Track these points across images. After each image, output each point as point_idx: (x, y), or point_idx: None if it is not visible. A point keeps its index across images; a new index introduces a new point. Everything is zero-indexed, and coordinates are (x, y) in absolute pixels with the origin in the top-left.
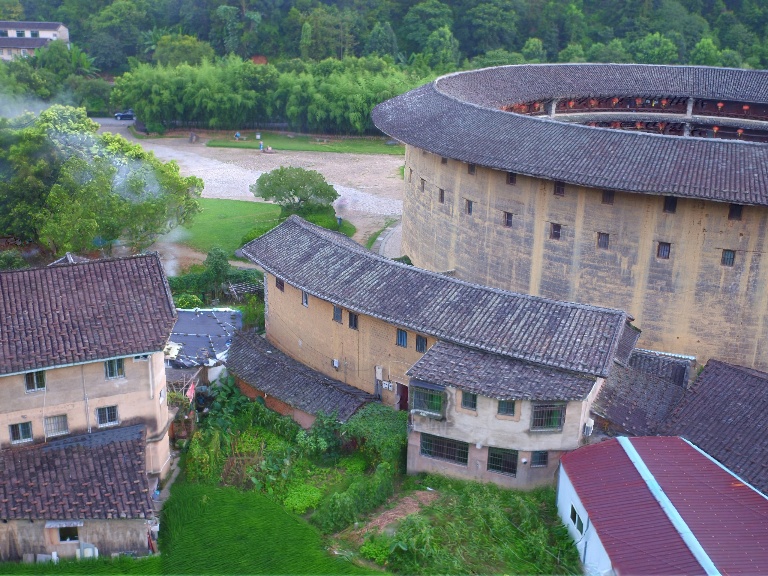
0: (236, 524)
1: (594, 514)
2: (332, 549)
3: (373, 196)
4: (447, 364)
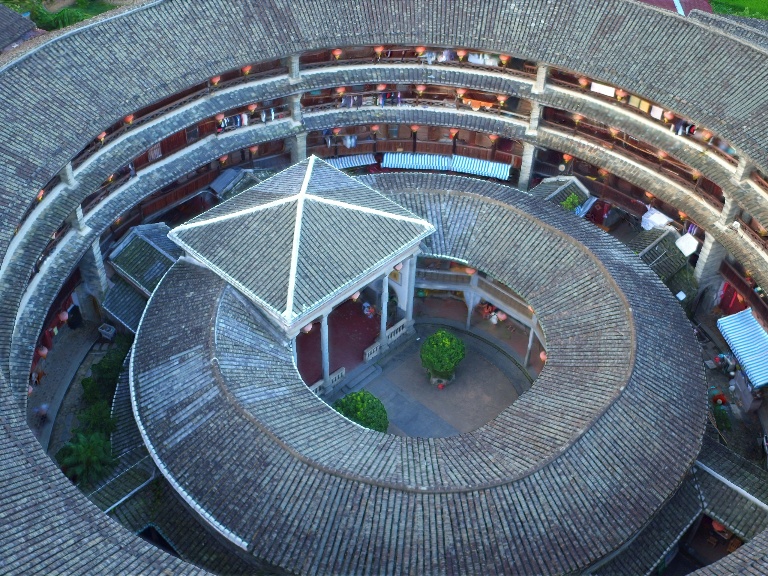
0: None
1: (710, 8)
2: None
3: None
4: None
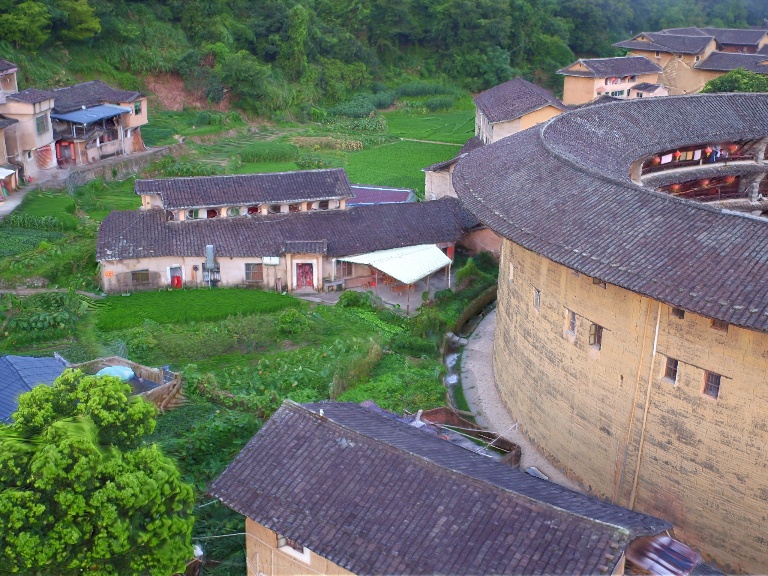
0: None
1: None
2: (422, 194)
3: None
4: None
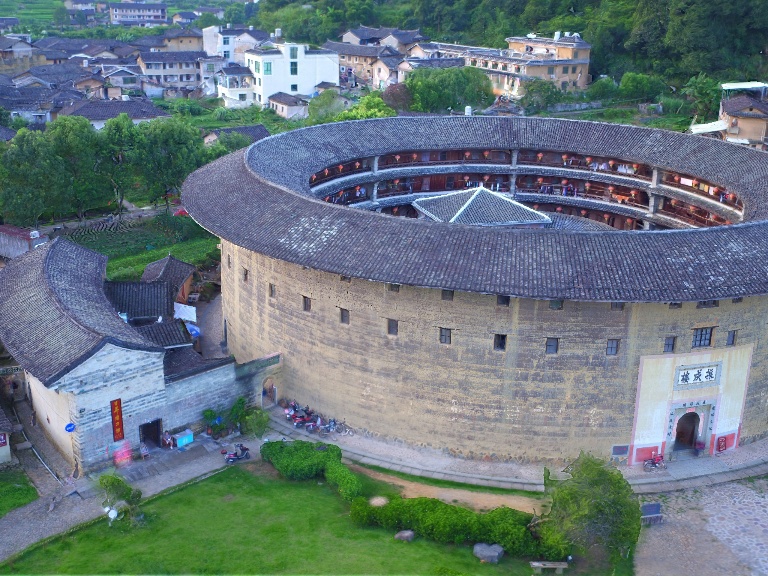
0: None
1: None
2: None
3: (763, 570)
4: None
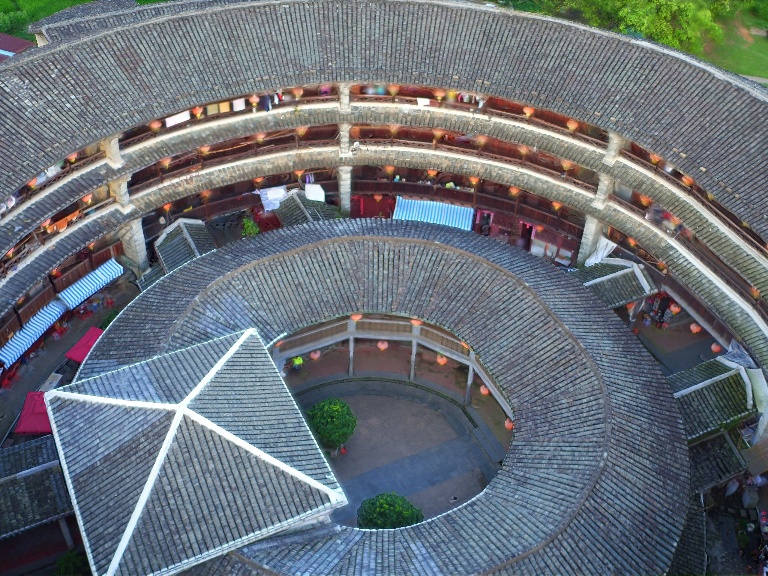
0: (145, 1)
1: None
2: None
3: None
4: (118, 4)
